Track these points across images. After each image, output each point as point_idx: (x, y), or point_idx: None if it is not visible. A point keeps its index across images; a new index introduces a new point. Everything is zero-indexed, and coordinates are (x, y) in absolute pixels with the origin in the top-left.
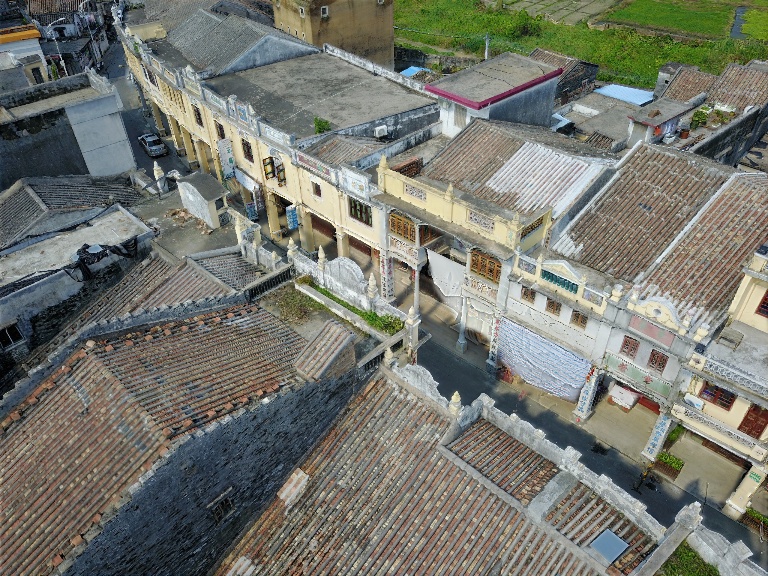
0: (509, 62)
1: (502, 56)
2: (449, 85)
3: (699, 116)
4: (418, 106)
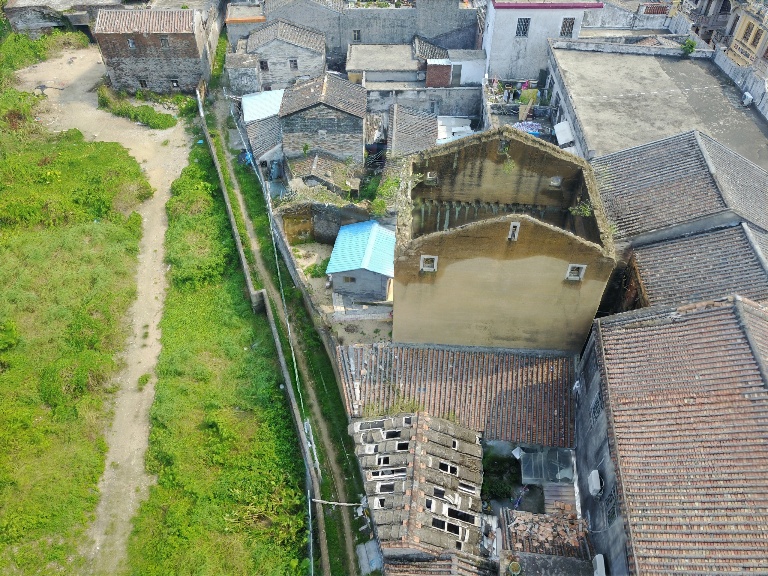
0: (509, 1)
1: (506, 4)
2: (583, 1)
3: (386, 5)
4: (589, 41)
